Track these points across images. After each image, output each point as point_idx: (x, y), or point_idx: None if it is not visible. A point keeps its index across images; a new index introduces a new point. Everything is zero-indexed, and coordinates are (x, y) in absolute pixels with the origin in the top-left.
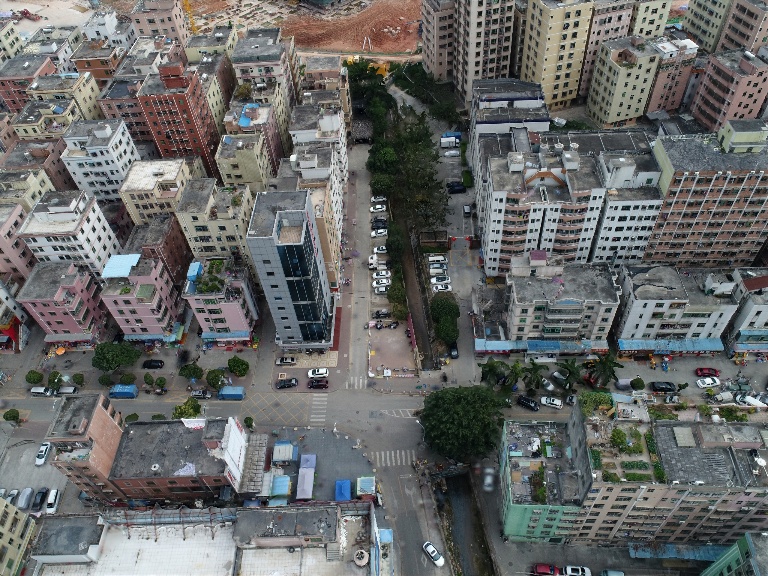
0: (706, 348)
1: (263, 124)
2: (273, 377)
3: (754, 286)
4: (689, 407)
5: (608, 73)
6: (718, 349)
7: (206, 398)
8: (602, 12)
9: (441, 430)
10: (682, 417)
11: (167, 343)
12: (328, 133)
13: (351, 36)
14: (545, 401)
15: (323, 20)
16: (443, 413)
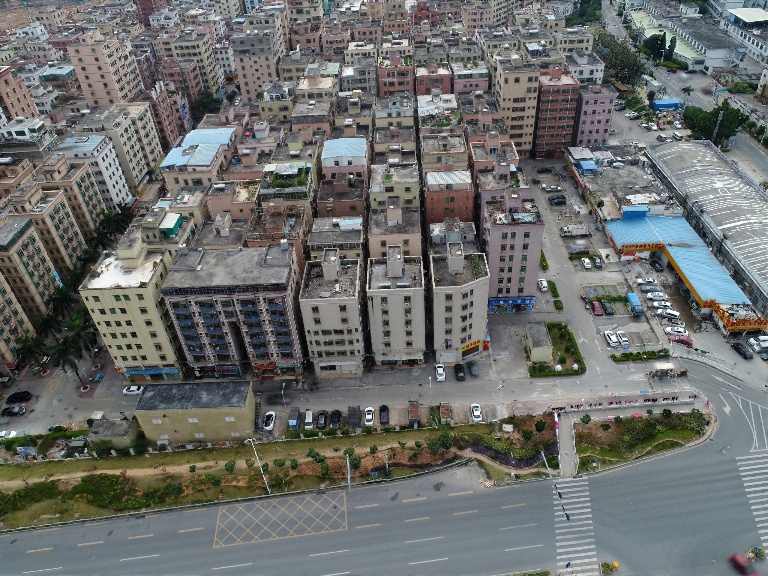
0: None
1: (174, 6)
2: None
3: None
4: None
5: None
6: None
7: None
8: None
9: None
10: None
11: None
12: None
13: None
14: None
15: None
16: None
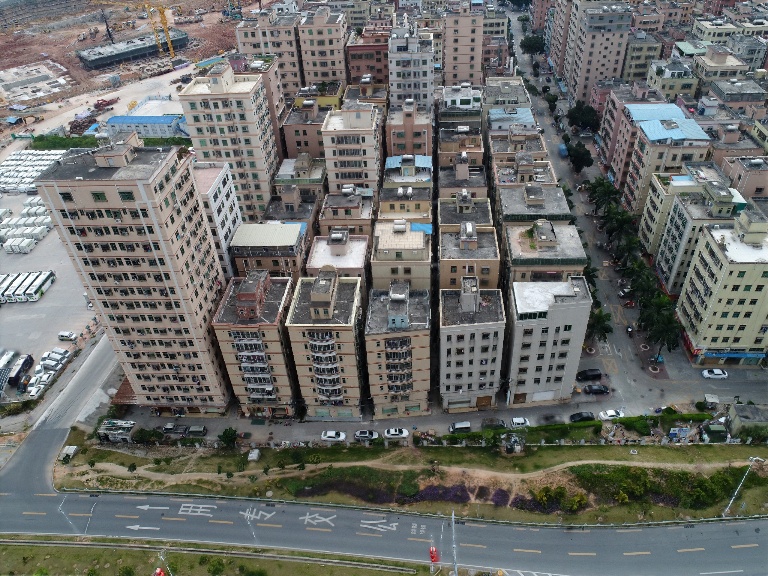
0: None
1: None
2: None
3: None
4: None
5: None
6: None
7: None
8: None
9: None
10: None
11: None
12: None
13: None
14: None
15: (200, 47)
16: None
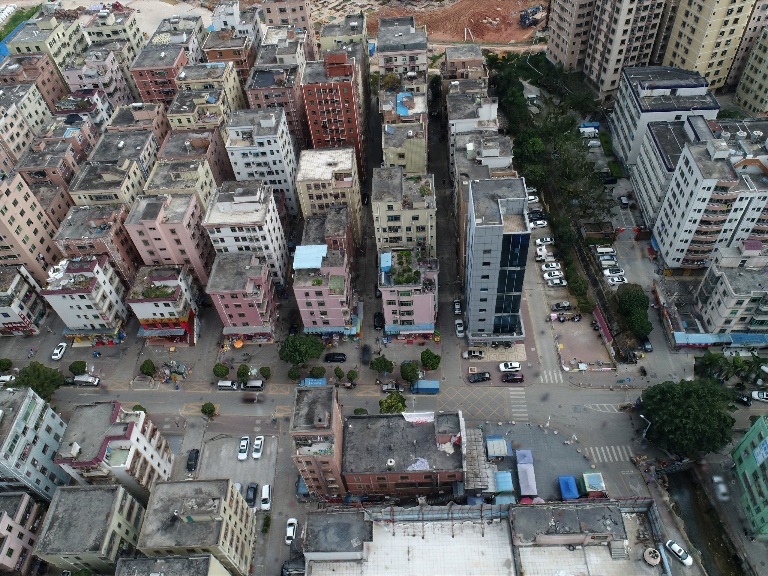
0: None
1: (423, 113)
2: (463, 371)
3: None
4: None
5: None
6: None
7: (399, 392)
8: None
9: (676, 425)
10: None
11: (346, 336)
12: (485, 122)
13: (450, 27)
14: (757, 396)
15: (416, 11)
16: (674, 407)
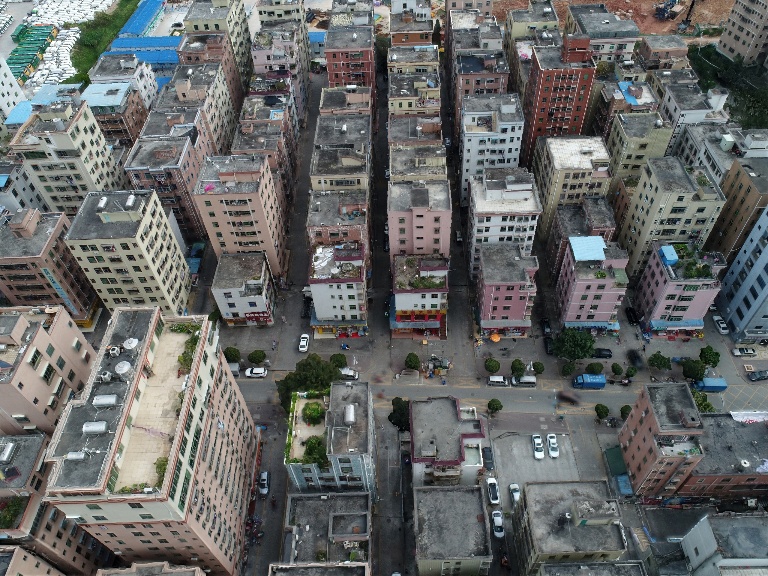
0: None
1: (655, 103)
2: (738, 369)
3: None
4: None
5: None
6: None
7: None
8: None
9: None
10: None
11: None
12: (710, 114)
13: None
14: None
15: None
16: None
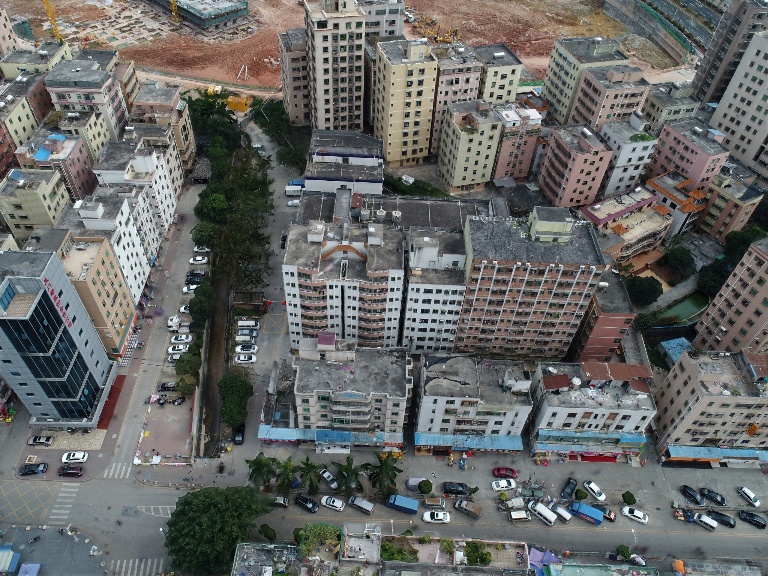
0: (504, 447)
1: (62, 160)
2: (20, 460)
3: (552, 385)
4: (434, 540)
5: (452, 136)
6: (516, 448)
7: None
8: (448, 73)
9: (179, 544)
10: (424, 552)
11: None
12: (142, 175)
13: (228, 63)
14: (325, 501)
15: (204, 42)
16: (187, 523)
